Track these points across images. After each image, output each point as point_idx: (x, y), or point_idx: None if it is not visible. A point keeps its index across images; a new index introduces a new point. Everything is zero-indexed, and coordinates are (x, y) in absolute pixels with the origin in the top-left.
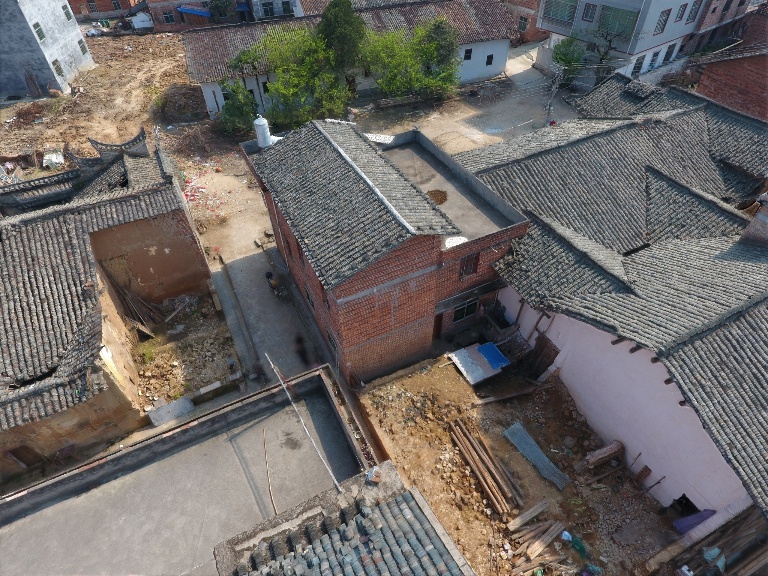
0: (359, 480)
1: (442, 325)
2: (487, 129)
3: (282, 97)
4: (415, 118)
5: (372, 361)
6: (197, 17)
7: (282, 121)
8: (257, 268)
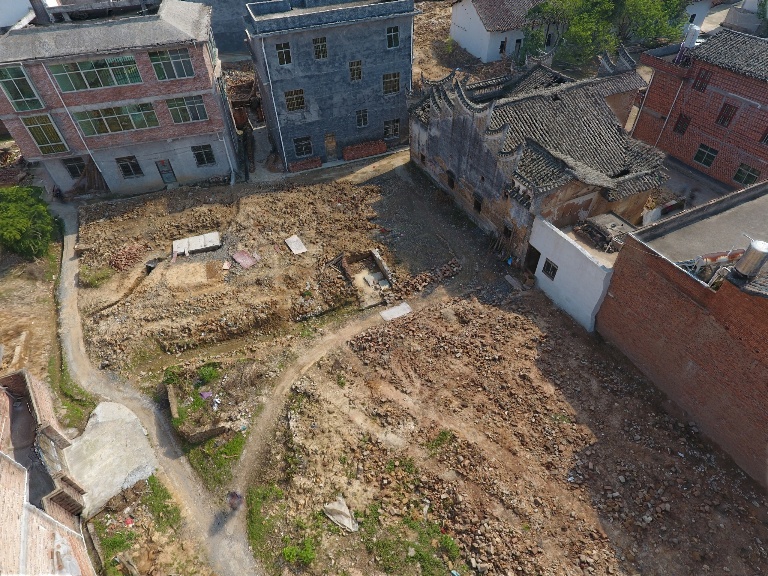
0: None
1: None
2: None
3: (577, 38)
4: None
5: None
6: None
7: (571, 59)
8: None
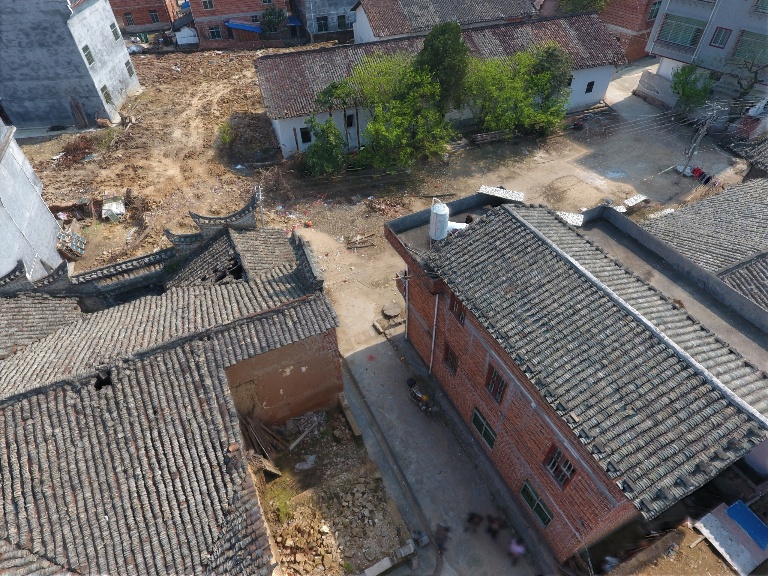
0: None
1: None
2: (608, 173)
3: (382, 139)
4: (519, 157)
5: (598, 537)
6: (247, 33)
7: (378, 165)
8: (386, 365)
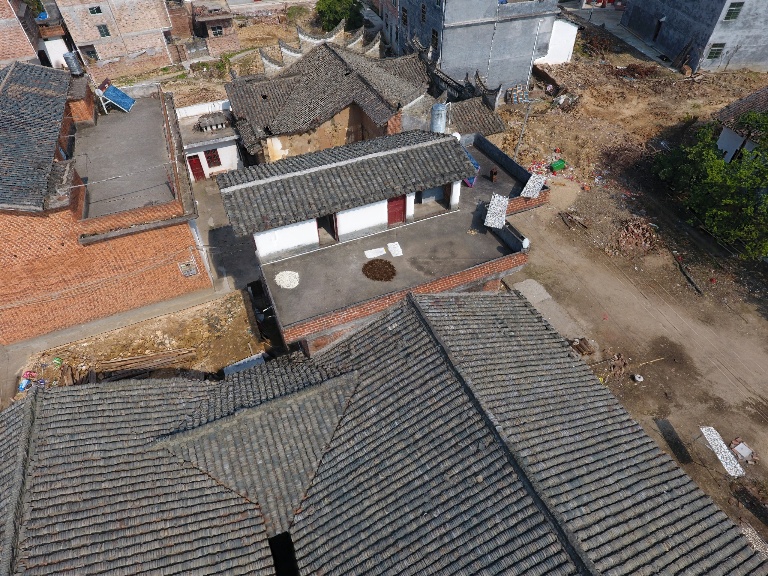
0: (66, 194)
1: None
2: None
3: None
4: None
5: None
6: None
7: (688, 204)
8: None
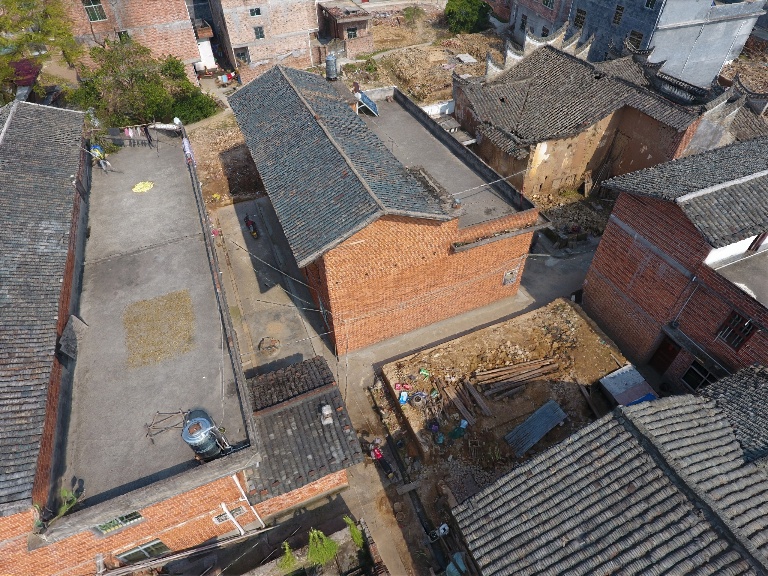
0: None
1: (671, 365)
2: None
3: None
4: None
5: (599, 303)
6: None
7: None
8: None
